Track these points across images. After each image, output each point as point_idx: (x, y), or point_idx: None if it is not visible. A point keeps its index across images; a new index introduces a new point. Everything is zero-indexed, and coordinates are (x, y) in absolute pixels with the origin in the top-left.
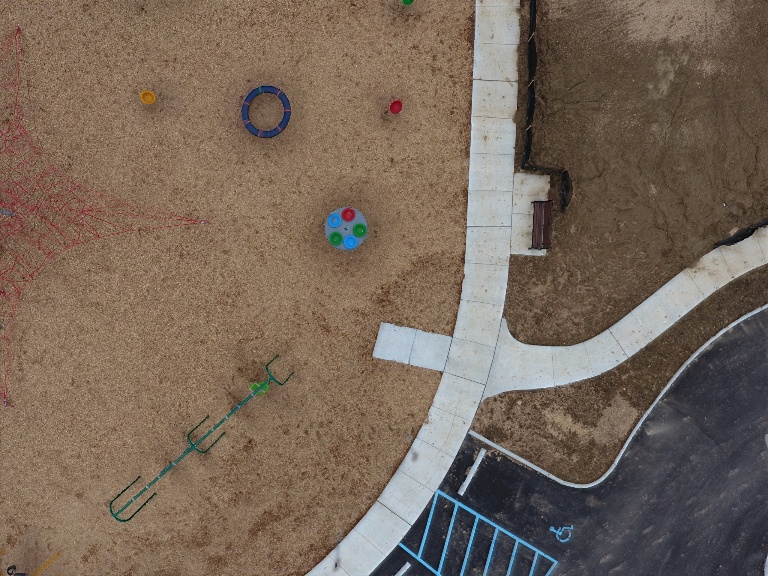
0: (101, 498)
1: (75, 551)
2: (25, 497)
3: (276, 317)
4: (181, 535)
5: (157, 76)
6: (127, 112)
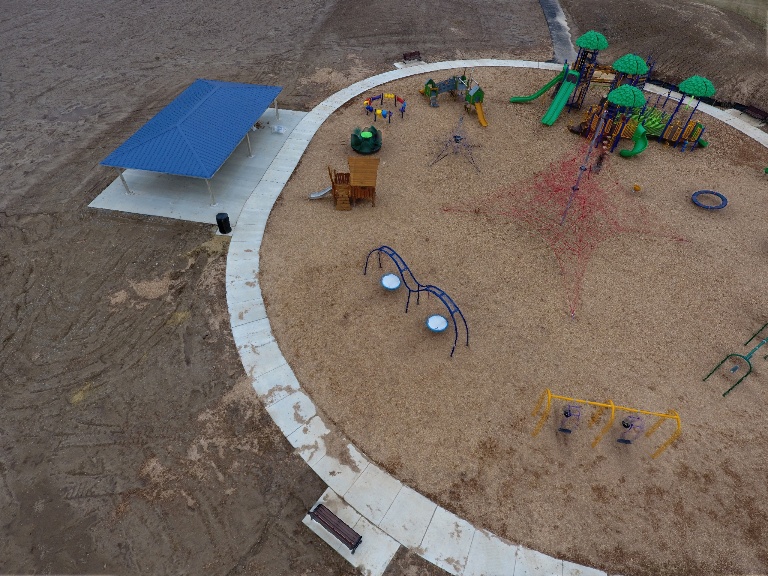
0: (673, 393)
1: (662, 436)
2: (602, 383)
3: (766, 292)
4: (765, 436)
5: (633, 184)
6: (621, 194)
